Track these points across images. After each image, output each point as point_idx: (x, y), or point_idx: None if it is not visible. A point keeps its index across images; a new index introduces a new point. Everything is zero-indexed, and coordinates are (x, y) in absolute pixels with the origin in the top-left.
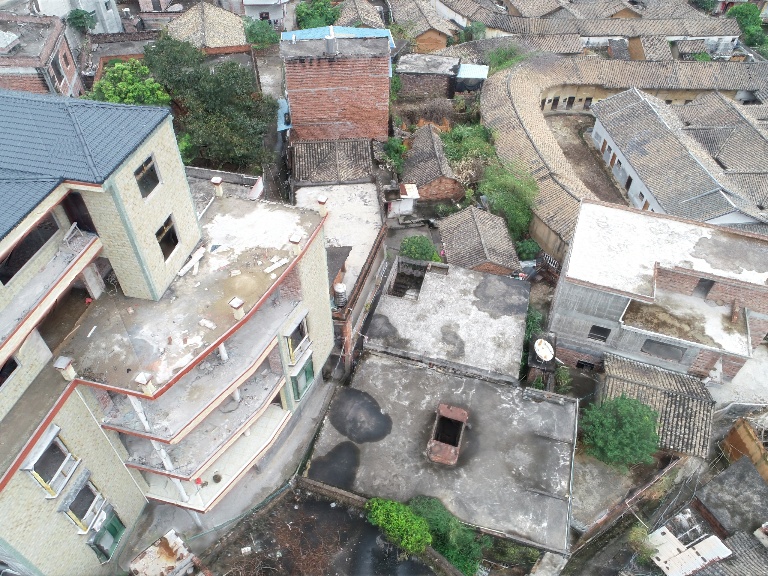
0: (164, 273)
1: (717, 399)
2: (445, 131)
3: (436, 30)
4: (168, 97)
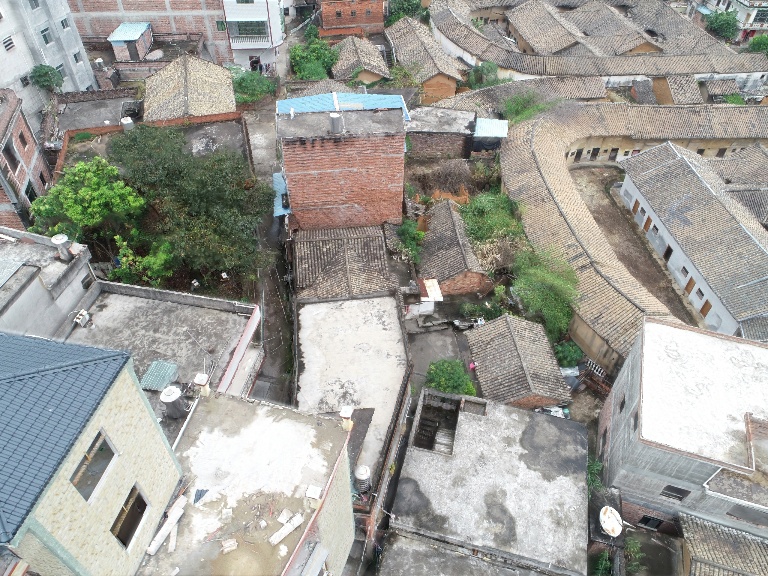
0: (126, 566)
1: None
2: (464, 202)
3: (445, 74)
4: (142, 202)
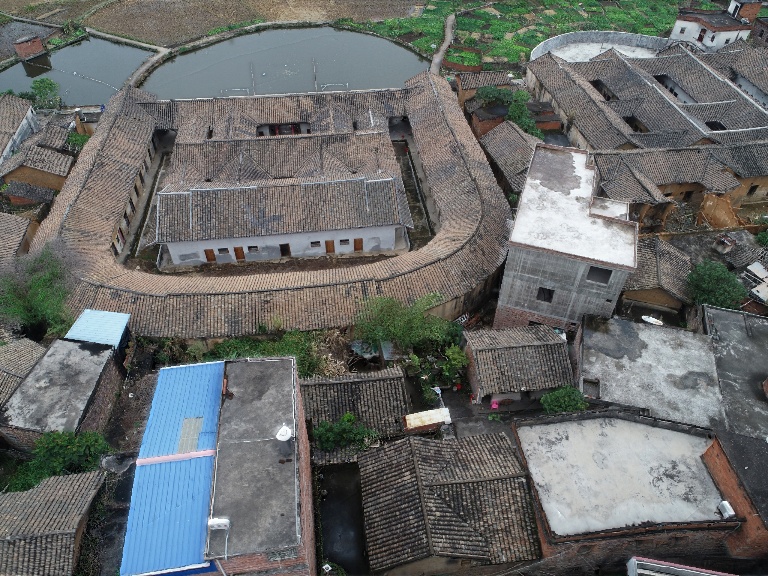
0: None
1: None
2: None
3: None
4: None
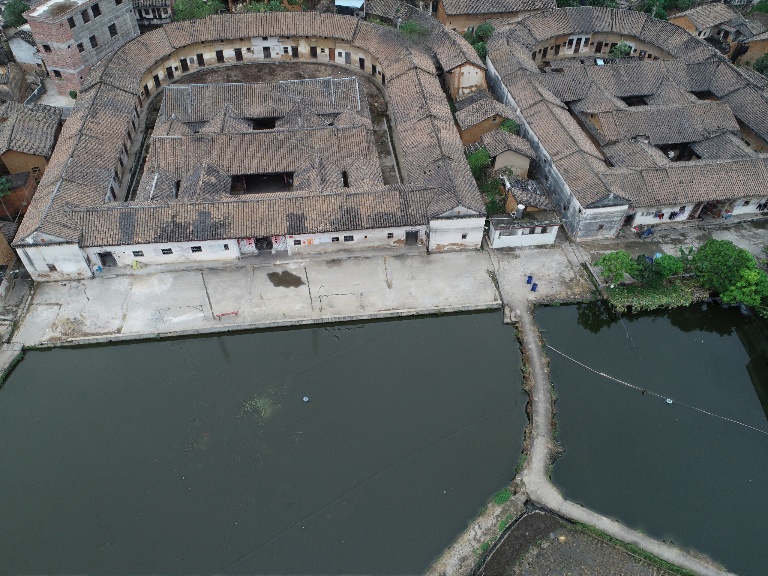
0: None
1: (51, 89)
2: None
3: (442, 0)
4: None
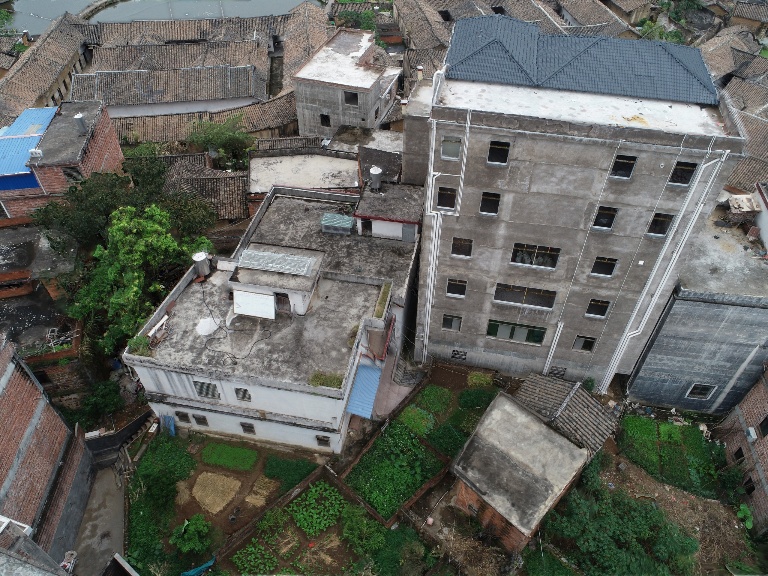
0: None
1: None
2: None
3: None
4: None
